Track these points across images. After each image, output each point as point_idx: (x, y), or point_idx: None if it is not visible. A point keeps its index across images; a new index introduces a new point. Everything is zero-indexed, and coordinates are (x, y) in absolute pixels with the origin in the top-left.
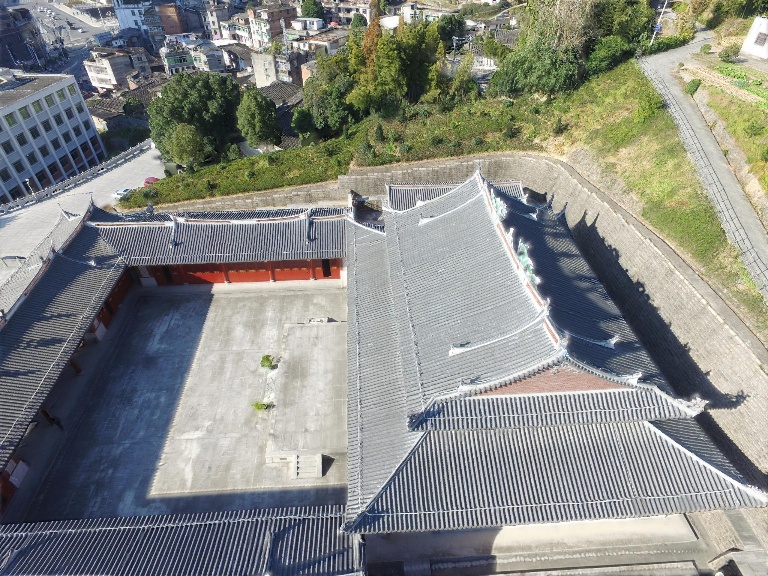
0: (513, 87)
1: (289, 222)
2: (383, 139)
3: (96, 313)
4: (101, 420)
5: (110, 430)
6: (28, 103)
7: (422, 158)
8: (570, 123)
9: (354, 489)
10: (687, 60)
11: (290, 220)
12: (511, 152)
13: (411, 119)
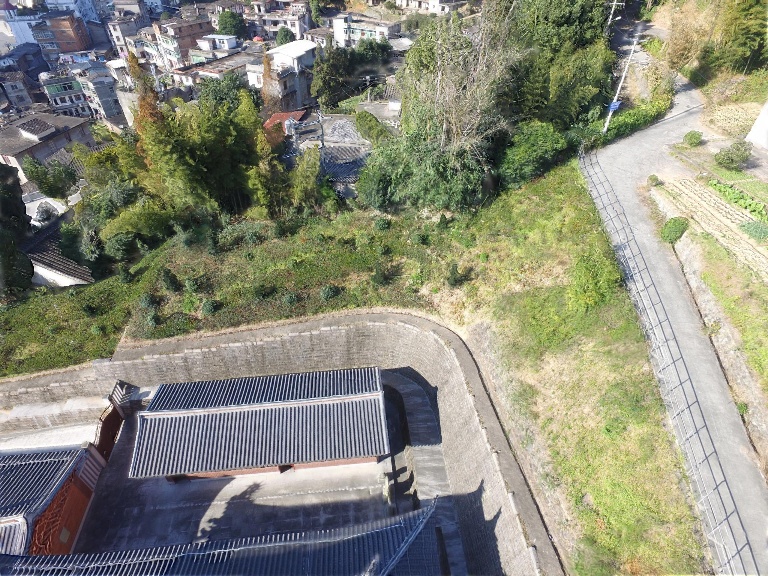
0: (386, 201)
1: None
2: (179, 287)
3: None
4: None
5: None
6: None
7: (239, 322)
8: (475, 267)
9: None
10: (663, 158)
11: None
12: (384, 309)
13: (231, 249)
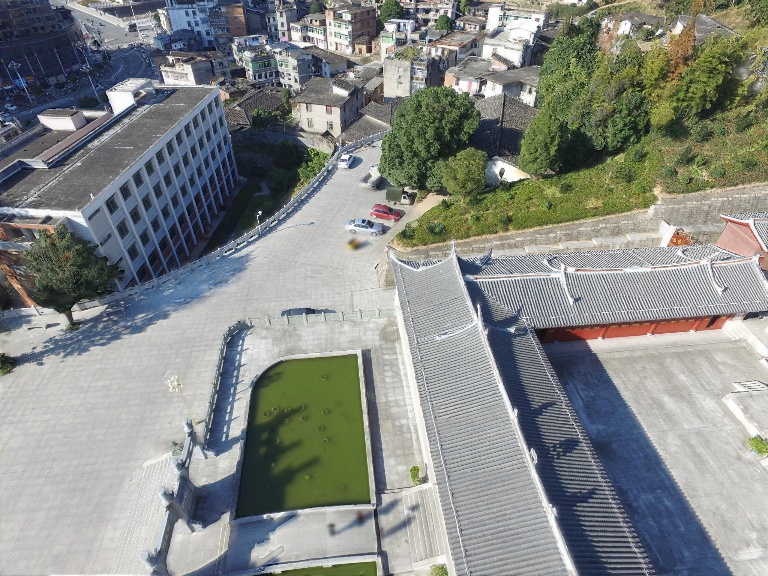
0: None
1: (687, 268)
2: (687, 162)
3: None
4: None
5: None
6: (190, 119)
7: (737, 183)
8: None
9: None
10: None
11: (688, 266)
12: None
13: (709, 139)
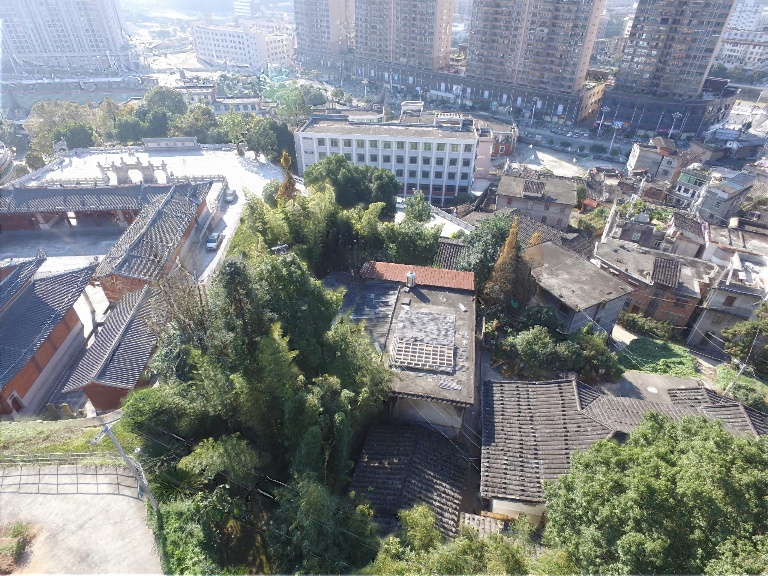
0: None
1: None
2: None
3: (102, 210)
4: (63, 239)
5: (54, 242)
6: (421, 141)
7: None
8: None
9: None
10: None
11: None
12: None
13: None
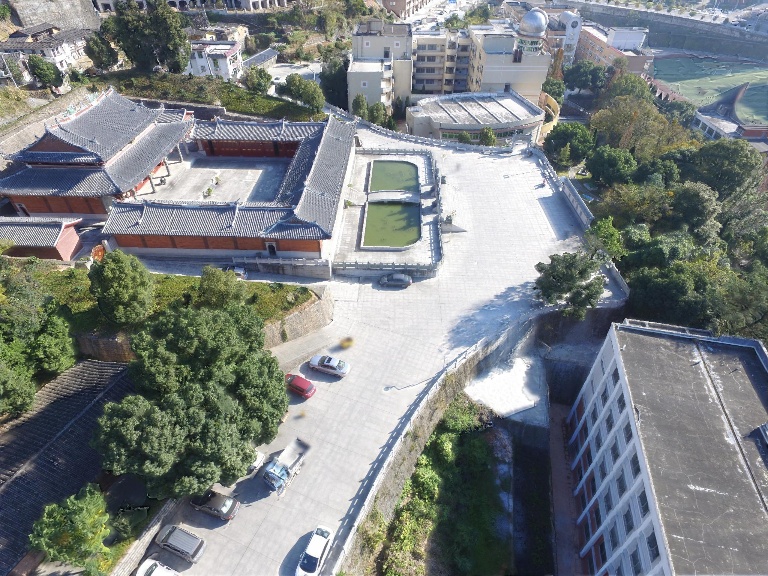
0: None
1: None
2: None
3: None
4: None
5: None
6: None
7: None
8: None
9: (188, 126)
10: None
11: None
12: None
13: None
